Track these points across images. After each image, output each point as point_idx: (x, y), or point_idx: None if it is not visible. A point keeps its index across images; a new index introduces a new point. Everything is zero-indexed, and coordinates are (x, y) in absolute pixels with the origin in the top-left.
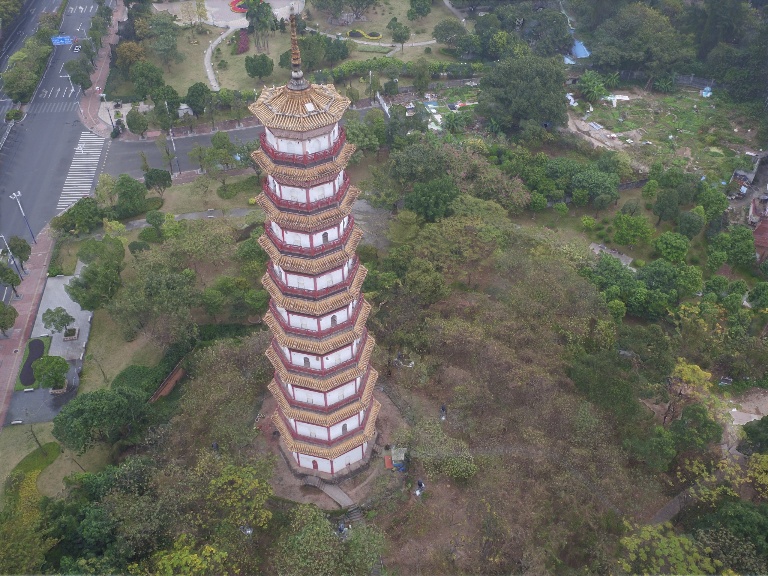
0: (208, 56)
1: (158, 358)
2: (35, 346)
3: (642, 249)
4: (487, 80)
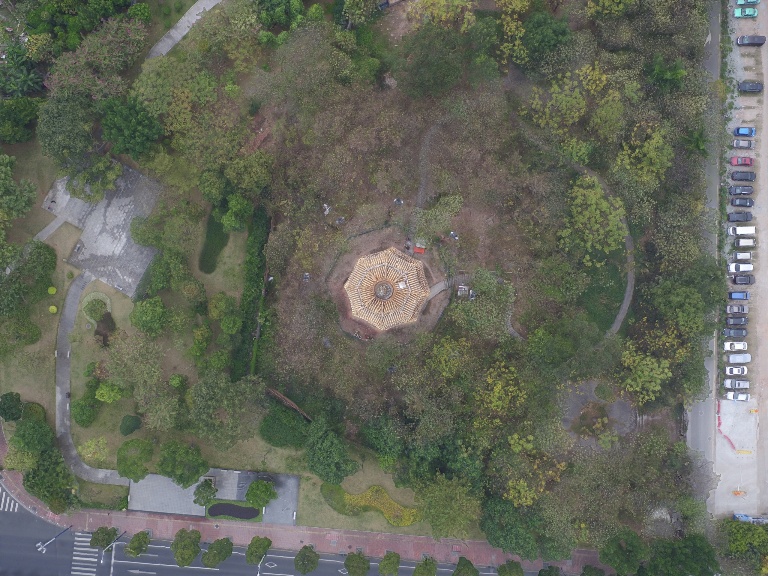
0: None
1: None
2: (217, 511)
3: None
4: None
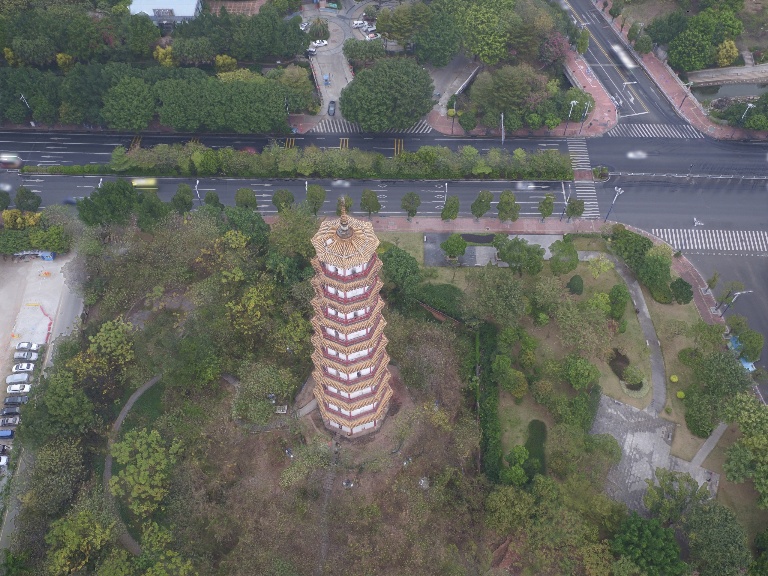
0: None
1: None
2: (489, 237)
3: None
4: None
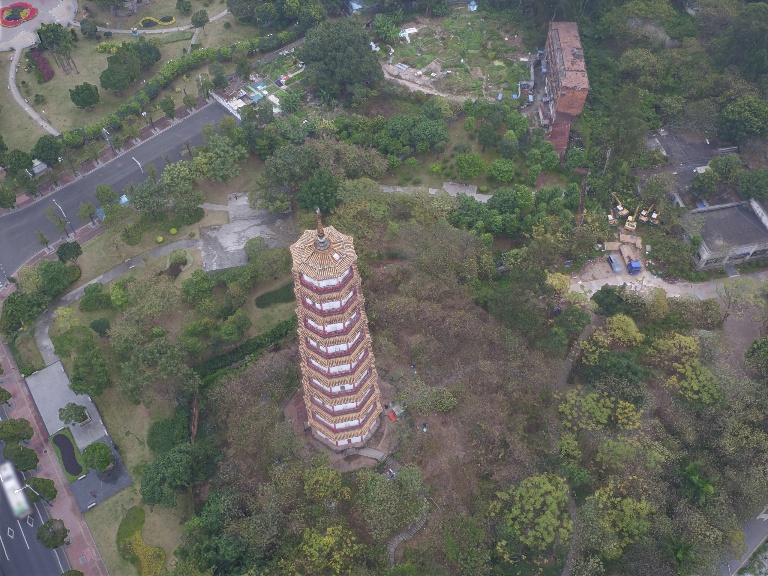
0: (15, 92)
1: (170, 408)
2: (61, 441)
3: (480, 176)
4: (305, 56)
